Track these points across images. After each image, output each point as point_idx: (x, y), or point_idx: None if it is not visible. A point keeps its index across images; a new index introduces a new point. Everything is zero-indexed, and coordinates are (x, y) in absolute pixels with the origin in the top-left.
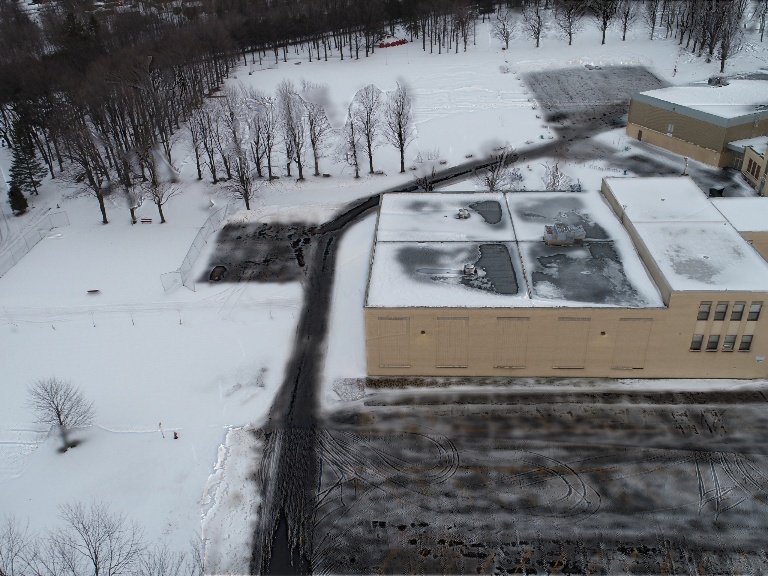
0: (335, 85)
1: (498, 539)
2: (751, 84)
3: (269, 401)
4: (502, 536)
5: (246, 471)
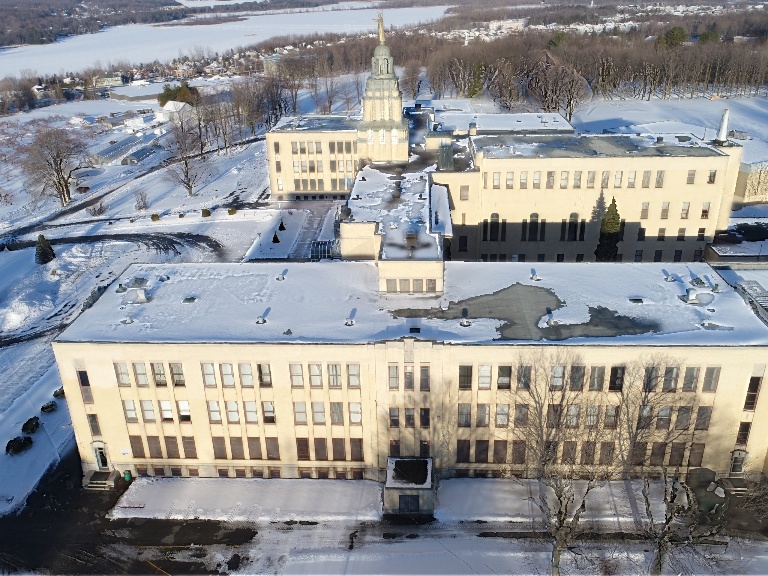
0: (761, 110)
1: None
2: (747, 144)
3: None
4: None
5: None
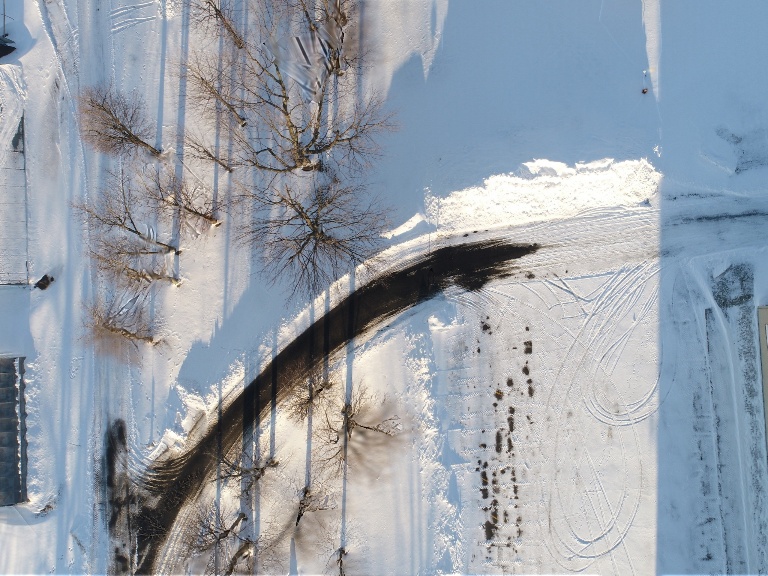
0: None
1: (519, 465)
2: None
3: (707, 188)
4: (523, 469)
5: (585, 195)
